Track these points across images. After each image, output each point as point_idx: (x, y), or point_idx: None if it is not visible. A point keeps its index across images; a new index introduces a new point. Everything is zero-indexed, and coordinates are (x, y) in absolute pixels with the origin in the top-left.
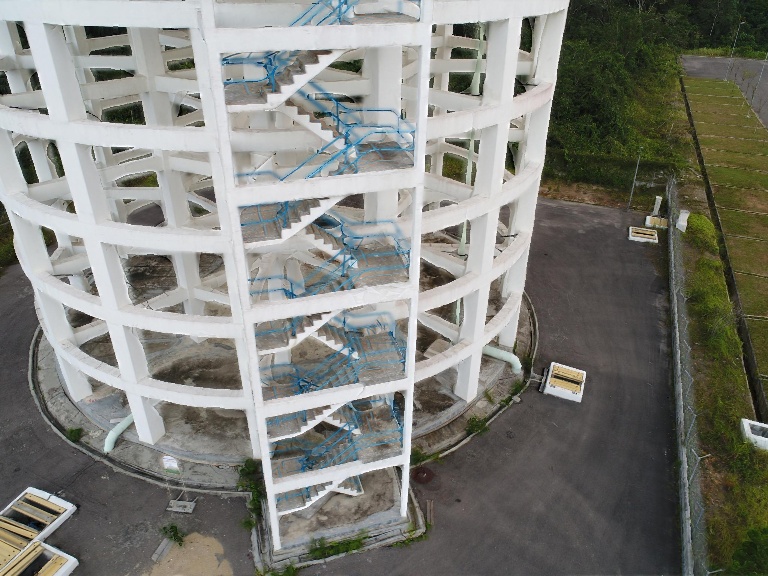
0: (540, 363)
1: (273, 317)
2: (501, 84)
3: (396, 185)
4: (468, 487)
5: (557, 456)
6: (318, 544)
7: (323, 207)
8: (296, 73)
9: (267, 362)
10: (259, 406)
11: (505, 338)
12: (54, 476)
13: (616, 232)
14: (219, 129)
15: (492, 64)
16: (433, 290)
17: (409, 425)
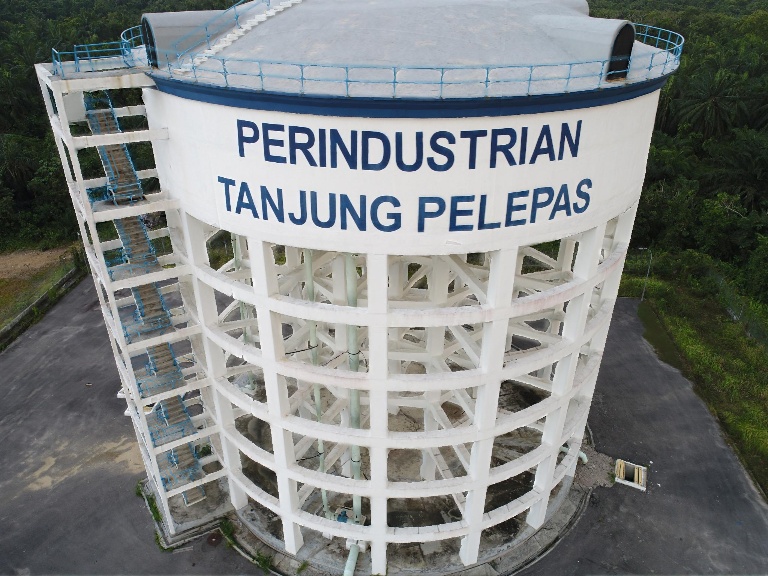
0: None
1: None
2: None
3: None
4: (206, 569)
5: None
6: (154, 497)
7: None
8: None
9: (241, 411)
10: None
11: None
12: None
13: None
14: None
15: None
16: (247, 441)
17: None
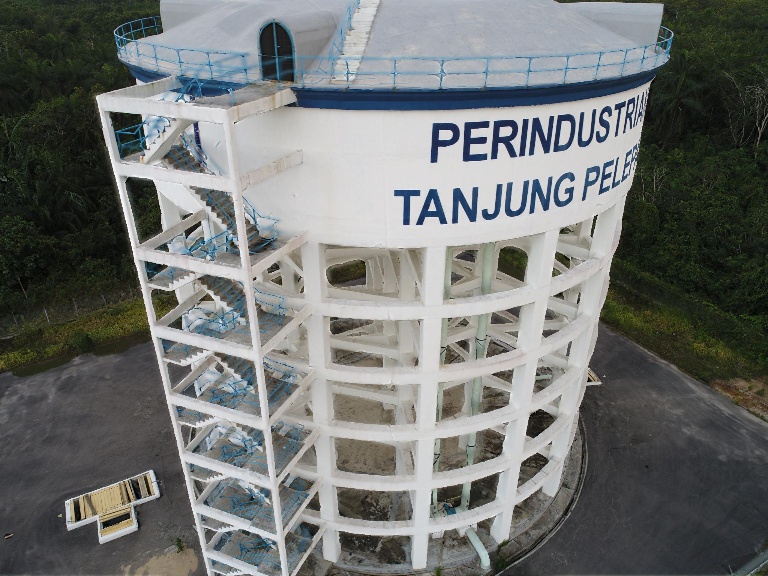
0: (515, 571)
1: (194, 463)
2: (422, 358)
3: (251, 425)
4: None
5: None
6: None
7: (215, 419)
8: (196, 352)
9: None
10: (192, 504)
11: (494, 532)
12: (167, 469)
13: (767, 477)
14: (160, 367)
15: (420, 341)
16: (369, 476)
17: (283, 564)
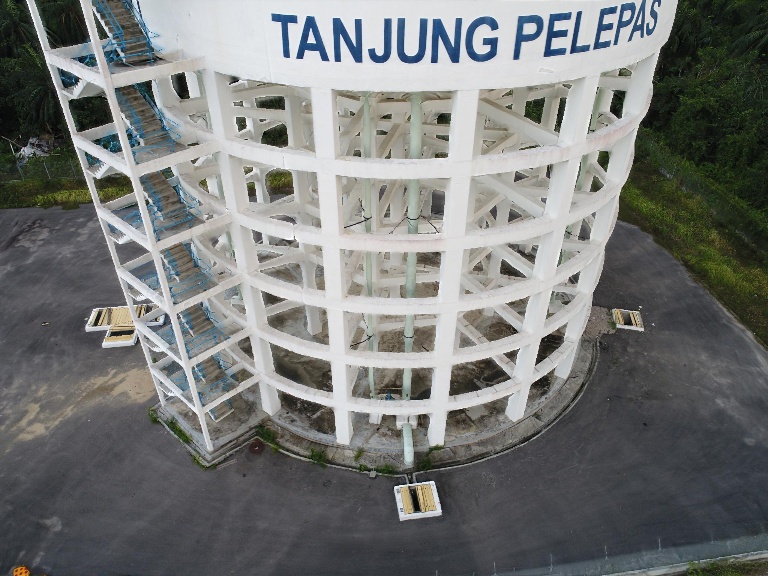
0: (436, 476)
1: None
2: None
3: None
4: (259, 476)
5: (322, 522)
6: (175, 421)
7: None
8: None
9: None
10: (133, 320)
11: (429, 434)
12: None
13: None
14: None
15: None
16: (290, 337)
17: (192, 392)
